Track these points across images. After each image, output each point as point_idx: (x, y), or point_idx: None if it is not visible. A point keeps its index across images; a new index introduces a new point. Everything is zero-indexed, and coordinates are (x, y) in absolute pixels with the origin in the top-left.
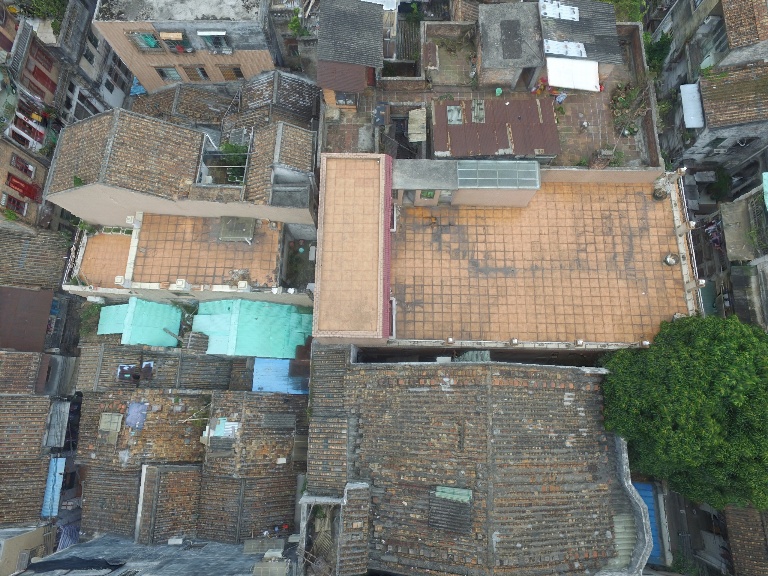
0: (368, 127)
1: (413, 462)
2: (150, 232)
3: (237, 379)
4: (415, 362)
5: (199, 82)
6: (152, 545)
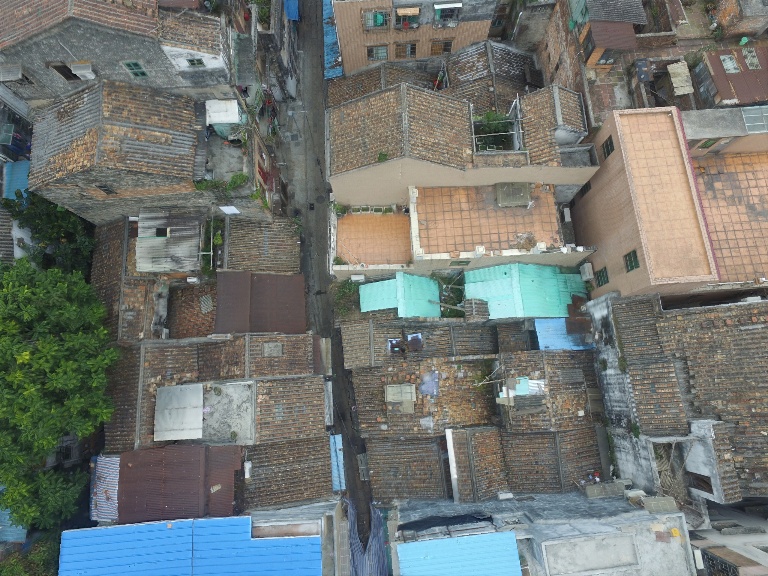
0: (622, 85)
1: (764, 394)
2: (426, 205)
3: (508, 342)
4: (741, 302)
5: (403, 59)
6: (479, 502)
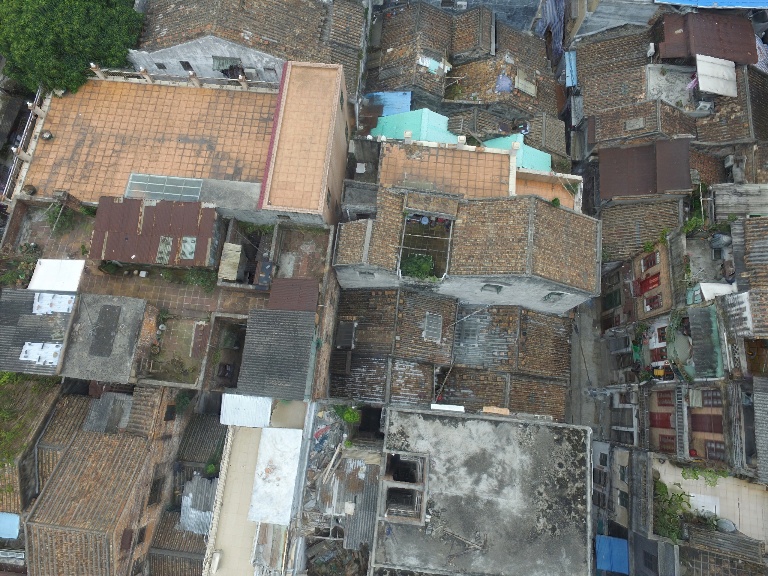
0: None
1: None
2: None
3: None
4: (269, 57)
5: None
6: (480, 6)
